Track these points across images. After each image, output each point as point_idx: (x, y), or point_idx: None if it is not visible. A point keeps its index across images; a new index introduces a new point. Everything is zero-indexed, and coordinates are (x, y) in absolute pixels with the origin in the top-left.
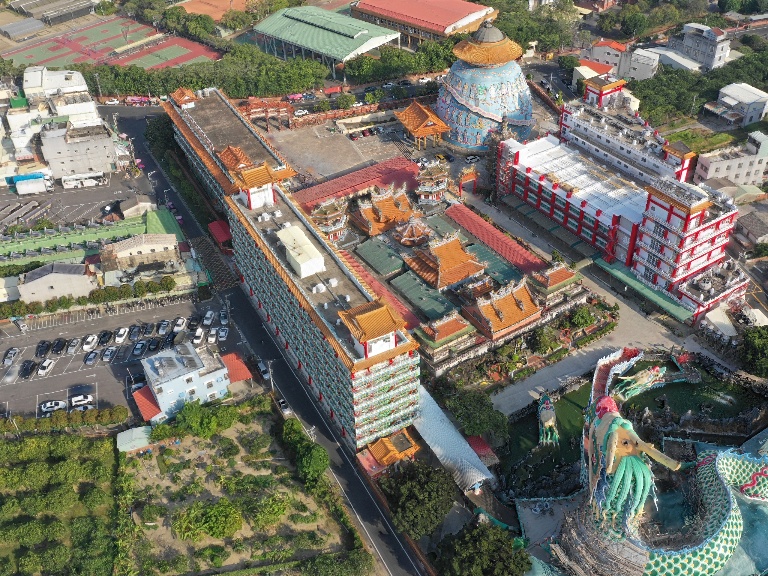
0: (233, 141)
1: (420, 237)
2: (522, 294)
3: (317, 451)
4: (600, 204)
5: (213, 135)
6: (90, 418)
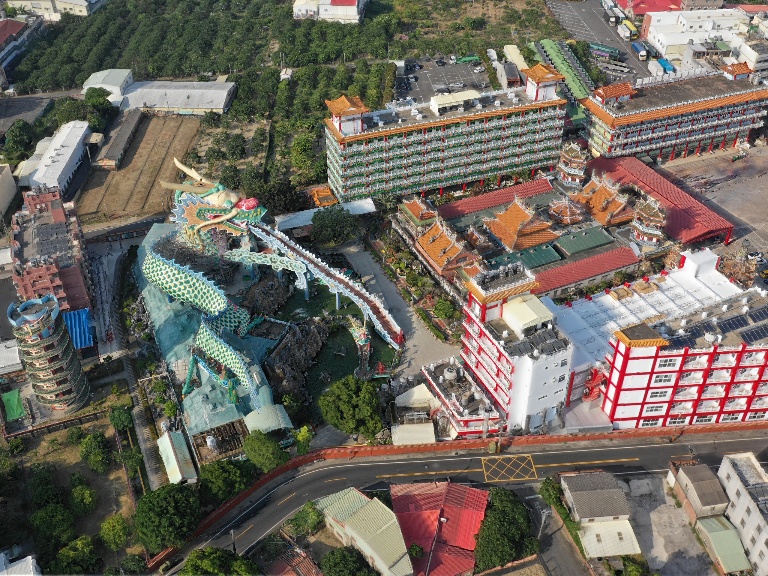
0: (663, 96)
1: (556, 214)
2: (455, 252)
3: (322, 161)
4: (591, 313)
5: (673, 88)
6: (384, 102)
